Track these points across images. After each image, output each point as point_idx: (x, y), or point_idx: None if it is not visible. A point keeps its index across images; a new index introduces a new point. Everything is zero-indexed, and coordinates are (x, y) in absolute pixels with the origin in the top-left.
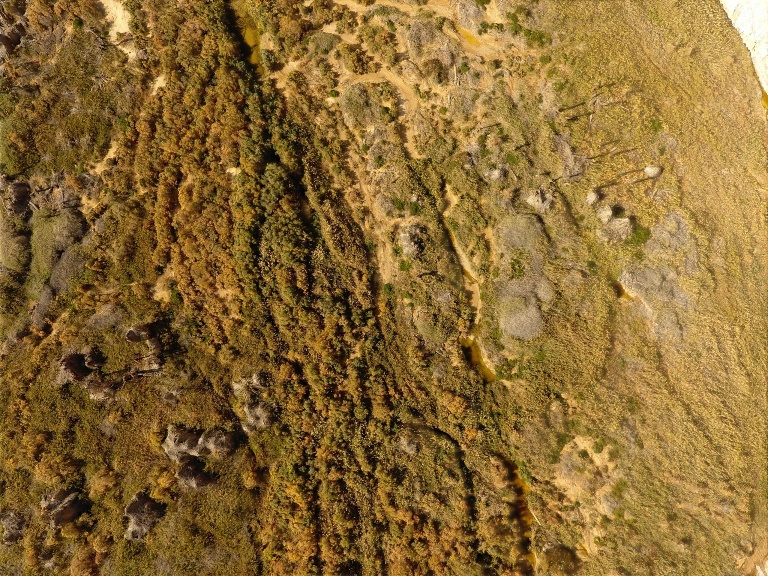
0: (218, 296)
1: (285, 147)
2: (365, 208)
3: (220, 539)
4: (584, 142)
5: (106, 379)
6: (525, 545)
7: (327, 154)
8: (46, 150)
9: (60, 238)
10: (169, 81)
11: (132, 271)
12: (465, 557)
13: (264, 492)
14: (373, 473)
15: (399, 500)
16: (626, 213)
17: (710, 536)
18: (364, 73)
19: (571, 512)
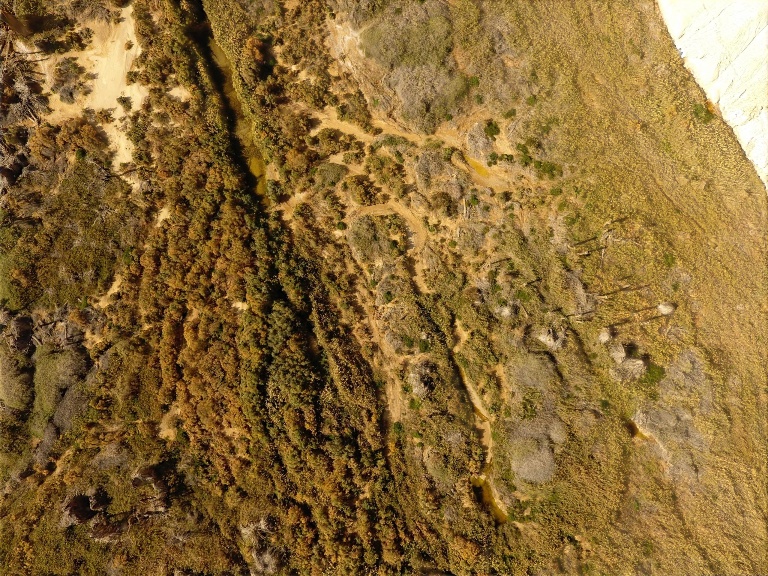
0: (225, 434)
1: (292, 285)
2: (374, 344)
3: None
4: (596, 279)
5: (111, 521)
6: None
7: (335, 290)
8: (49, 284)
9: (64, 377)
10: (174, 214)
11: (137, 409)
12: None
13: None
14: None
15: None
16: (639, 351)
17: None
18: (372, 205)
19: None
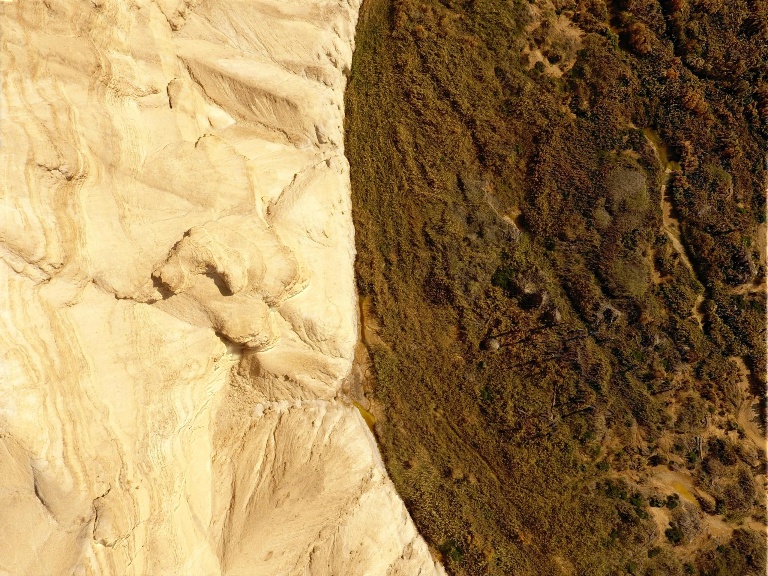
0: None
1: None
2: None
3: None
4: (564, 375)
5: None
6: None
7: None
8: None
9: None
10: None
11: None
12: None
13: None
14: None
15: (744, 5)
16: (517, 301)
17: None
18: None
19: (565, 4)
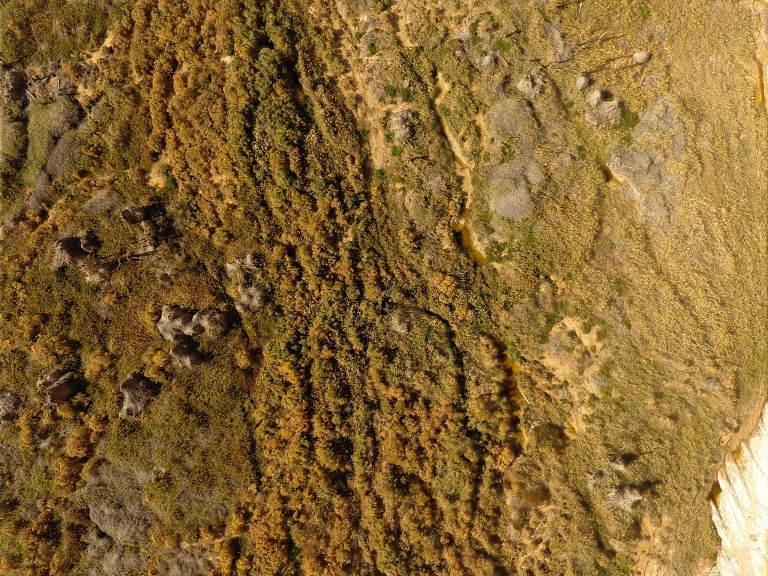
0: (212, 182)
1: (279, 32)
2: (358, 96)
3: (214, 418)
4: (574, 29)
5: (102, 262)
6: (514, 423)
7: (320, 41)
8: (43, 39)
9: (56, 123)
10: None
11: (127, 157)
12: (455, 431)
13: (257, 373)
14: (365, 352)
15: (390, 378)
16: (615, 99)
17: (696, 413)
18: None
19: (559, 391)
